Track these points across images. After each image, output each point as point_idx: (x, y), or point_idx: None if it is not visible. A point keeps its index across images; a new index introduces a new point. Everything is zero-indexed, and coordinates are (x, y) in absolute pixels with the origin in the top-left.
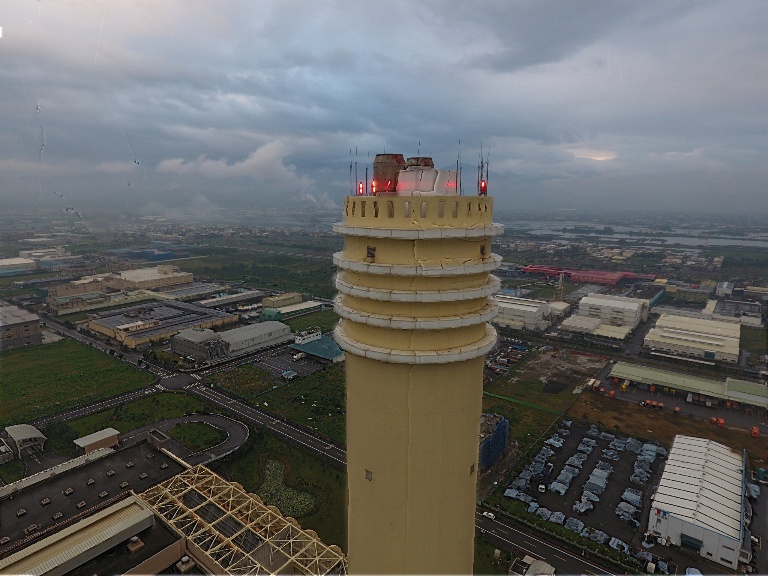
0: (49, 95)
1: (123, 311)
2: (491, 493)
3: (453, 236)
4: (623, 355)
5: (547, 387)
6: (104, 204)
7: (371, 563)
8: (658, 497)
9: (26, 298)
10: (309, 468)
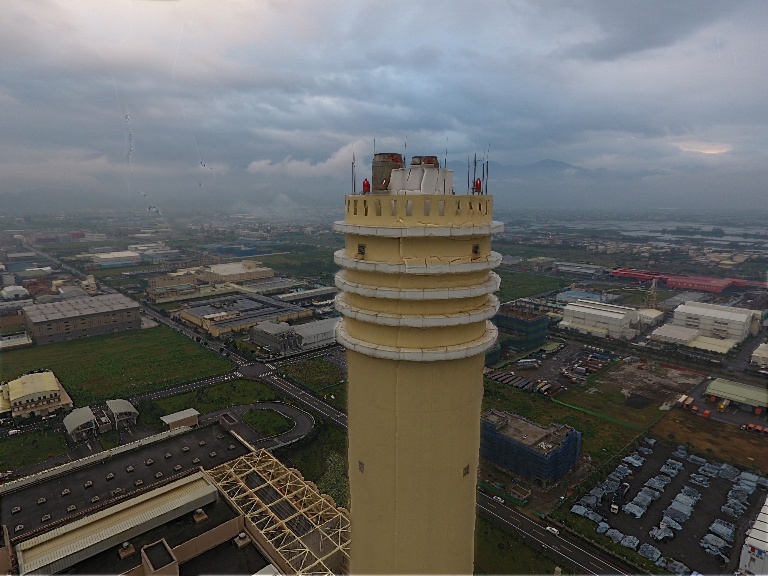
0: (136, 105)
1: (210, 302)
2: (556, 507)
3: (437, 234)
4: (724, 371)
5: (629, 401)
6: (179, 203)
7: (364, 553)
8: (754, 533)
9: (131, 287)
10: None
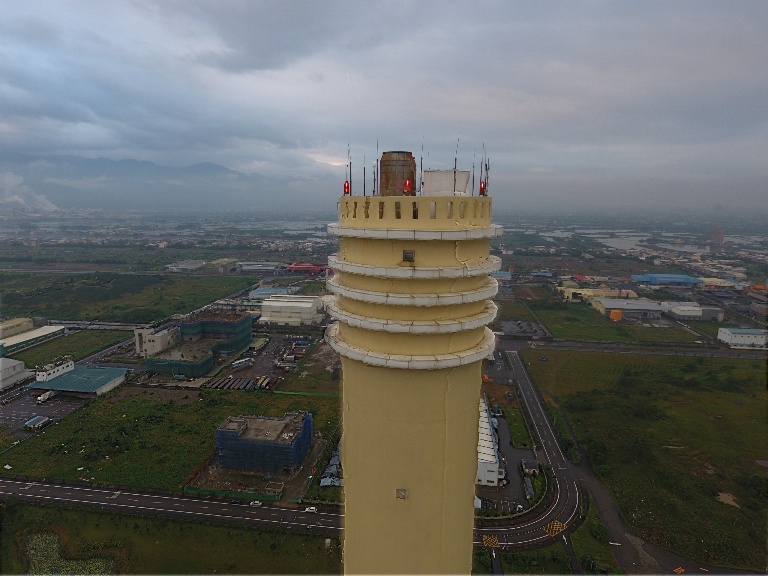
0: None
1: None
2: (308, 488)
3: (489, 235)
4: None
5: (334, 375)
6: None
7: None
8: None
9: None
10: (94, 528)
